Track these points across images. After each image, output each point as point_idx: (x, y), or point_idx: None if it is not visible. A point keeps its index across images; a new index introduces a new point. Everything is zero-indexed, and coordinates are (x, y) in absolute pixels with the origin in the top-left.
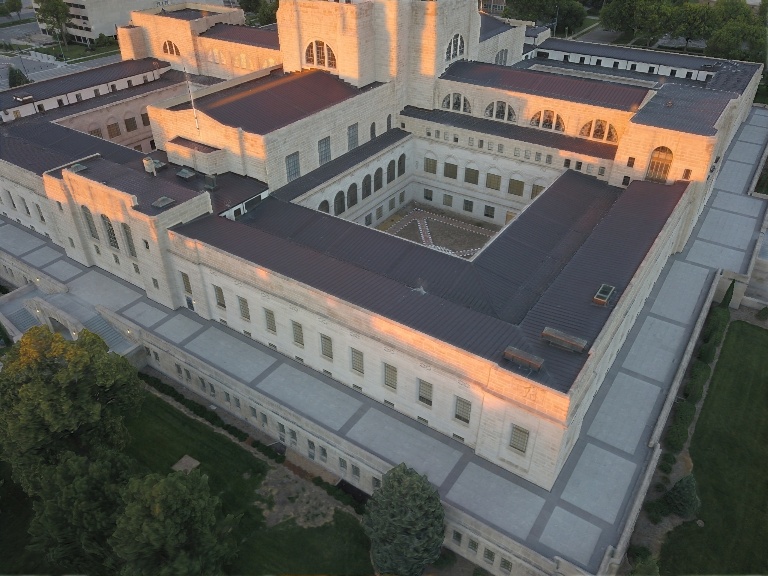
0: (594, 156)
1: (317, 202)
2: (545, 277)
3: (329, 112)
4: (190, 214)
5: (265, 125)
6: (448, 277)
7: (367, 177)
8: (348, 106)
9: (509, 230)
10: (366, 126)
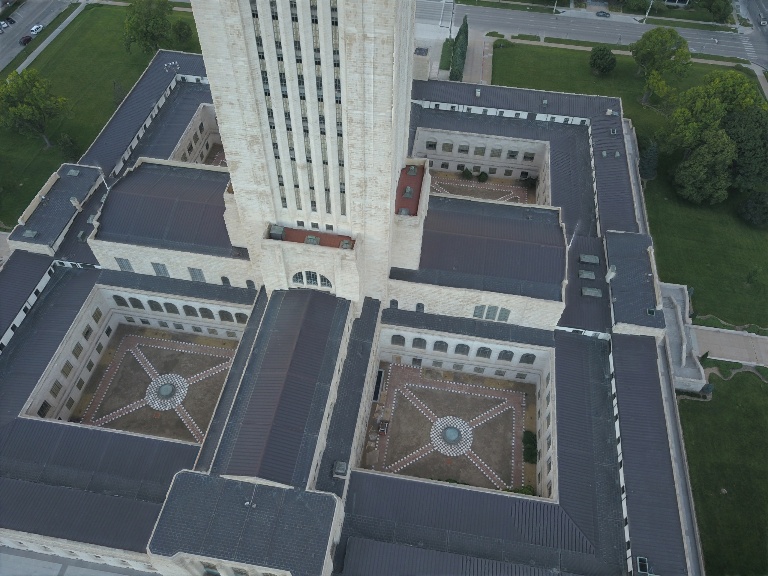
0: (202, 462)
1: (126, 295)
2: (16, 469)
3: (160, 252)
4: (33, 250)
5: (125, 228)
6: (3, 409)
7: (190, 306)
8: (185, 256)
9: (72, 428)
10: (214, 275)
